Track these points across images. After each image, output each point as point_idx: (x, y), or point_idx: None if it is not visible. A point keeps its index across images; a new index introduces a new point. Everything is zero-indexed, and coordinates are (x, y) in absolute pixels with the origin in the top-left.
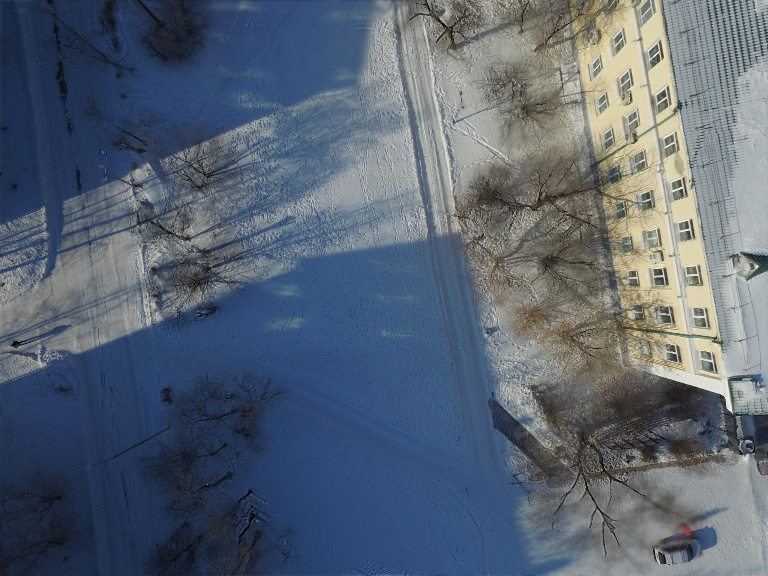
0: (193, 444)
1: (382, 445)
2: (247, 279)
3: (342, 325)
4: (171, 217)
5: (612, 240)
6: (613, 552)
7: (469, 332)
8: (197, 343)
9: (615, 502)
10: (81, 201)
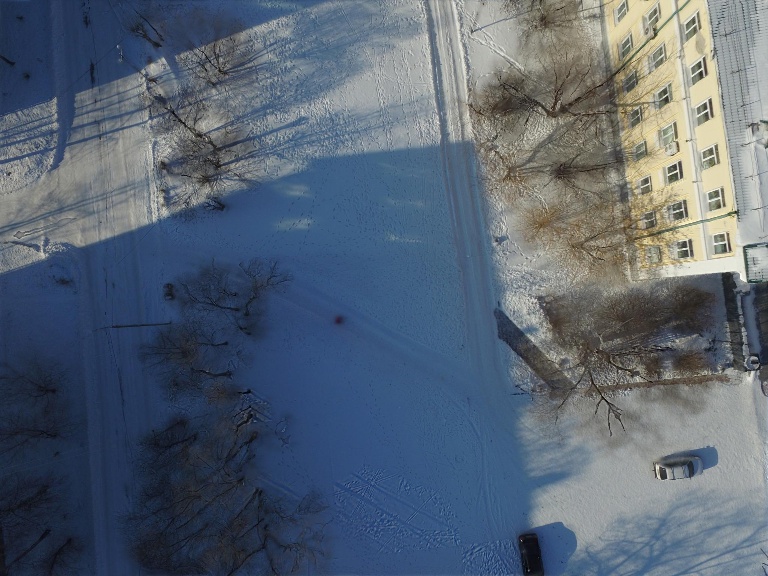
0: (194, 335)
1: (385, 350)
2: (257, 178)
3: (350, 228)
4: (183, 113)
5: (625, 151)
6: (613, 468)
7: (478, 241)
8: (203, 240)
9: None
10: (93, 94)
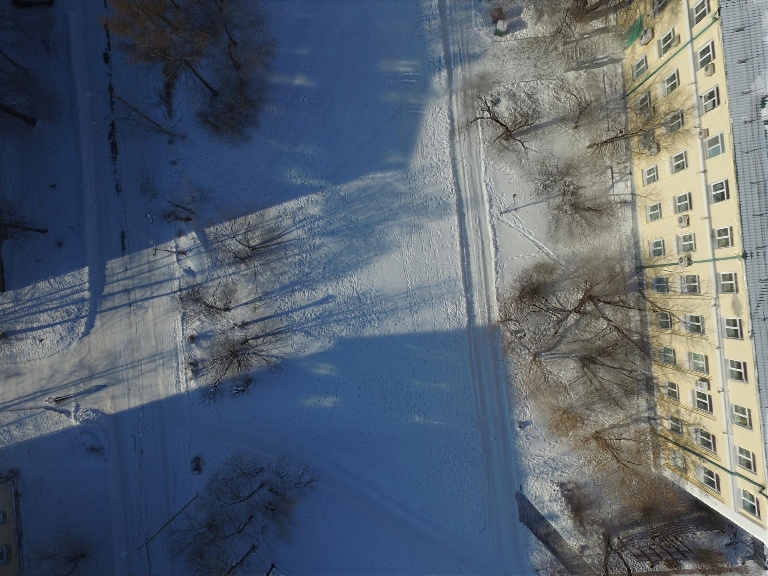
0: (221, 519)
1: (407, 530)
2: (284, 354)
3: (375, 407)
4: (212, 286)
5: (653, 346)
6: None
7: (501, 424)
8: (230, 413)
9: None
10: (124, 263)
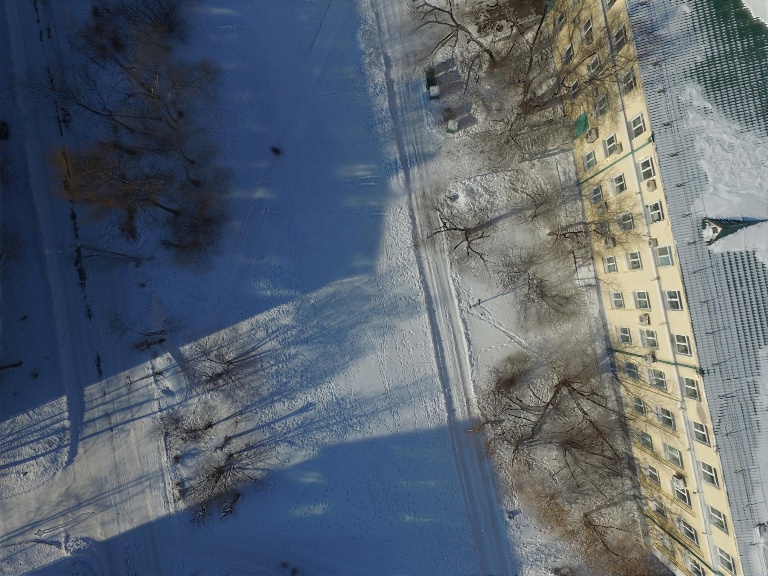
0: None
1: None
2: (269, 466)
3: (365, 510)
4: (192, 404)
5: (630, 428)
6: None
7: (491, 515)
8: (221, 530)
9: None
10: (102, 387)
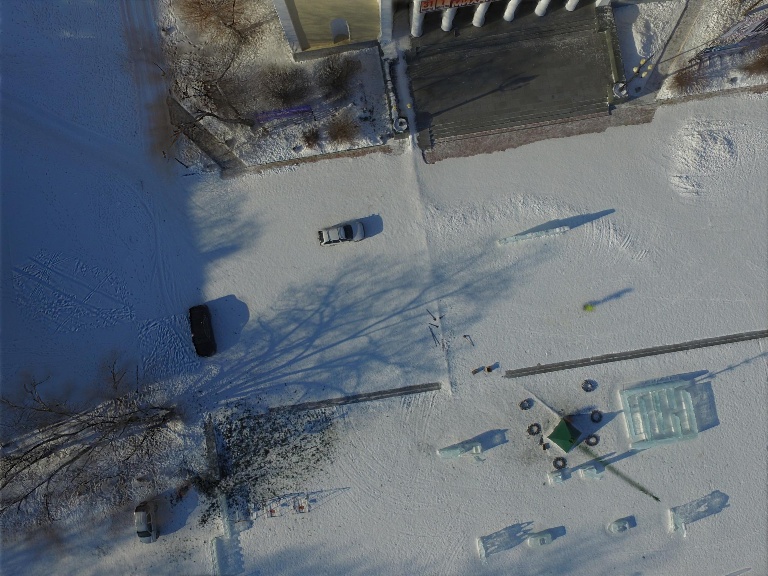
0: None
1: (63, 142)
2: None
3: (28, 29)
4: None
5: None
6: (283, 240)
7: (150, 34)
8: None
9: (285, 192)
10: None
